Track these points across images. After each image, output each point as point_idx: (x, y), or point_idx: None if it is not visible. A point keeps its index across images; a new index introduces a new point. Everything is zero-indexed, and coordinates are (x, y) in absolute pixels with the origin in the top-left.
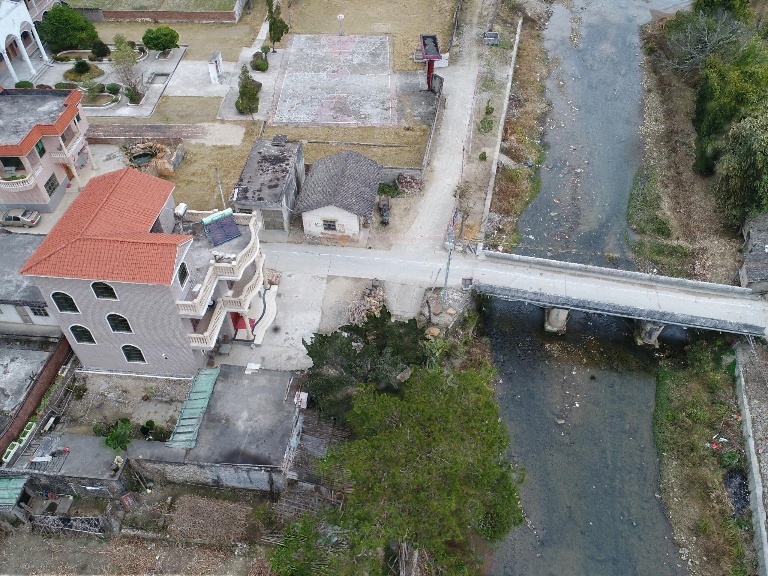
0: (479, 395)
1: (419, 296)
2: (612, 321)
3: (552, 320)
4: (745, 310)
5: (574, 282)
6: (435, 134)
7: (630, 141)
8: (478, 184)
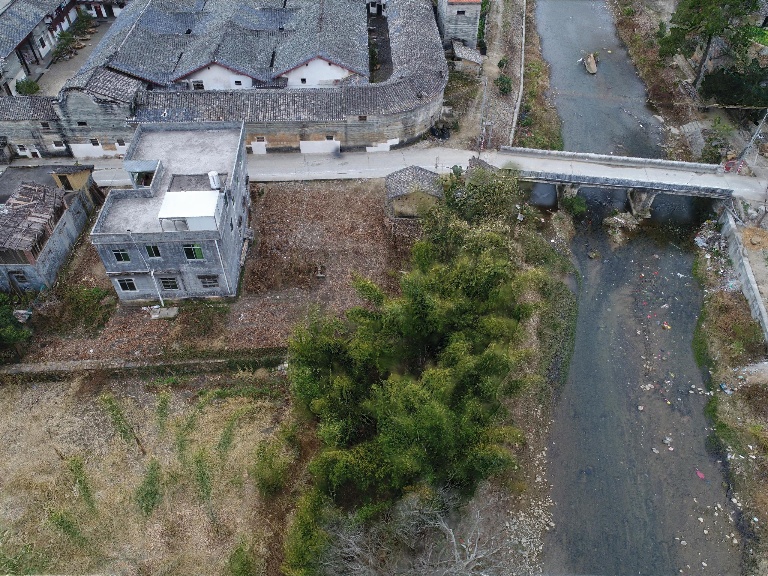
0: (711, 8)
1: (759, 174)
2: (591, 200)
3: None
4: (506, 166)
5: None
6: None
7: (571, 475)
8: None
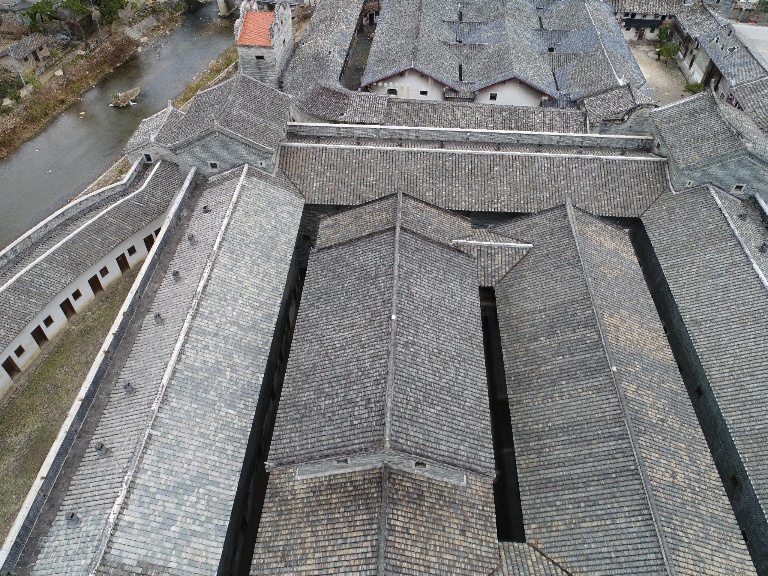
0: None
1: None
2: None
3: (219, 8)
4: None
5: None
6: None
7: None
8: None
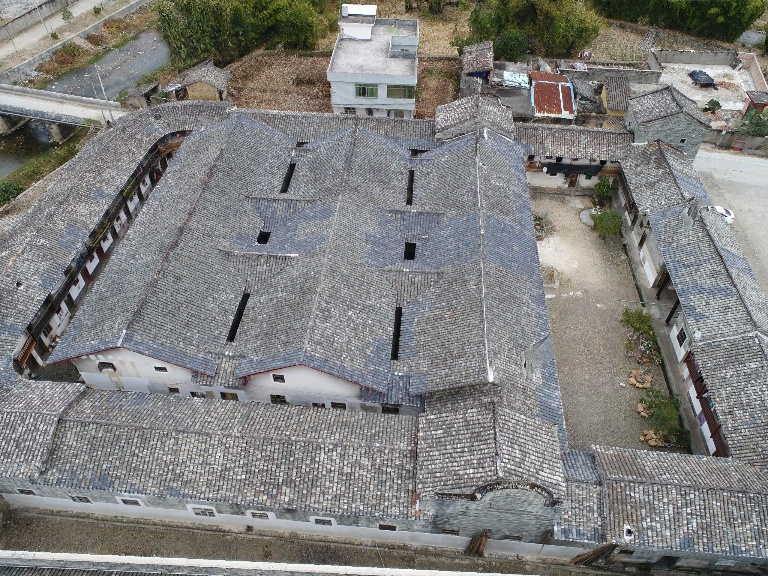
0: None
1: None
2: None
3: None
4: (109, 116)
5: (12, 98)
6: (39, 23)
7: None
8: (32, 51)
